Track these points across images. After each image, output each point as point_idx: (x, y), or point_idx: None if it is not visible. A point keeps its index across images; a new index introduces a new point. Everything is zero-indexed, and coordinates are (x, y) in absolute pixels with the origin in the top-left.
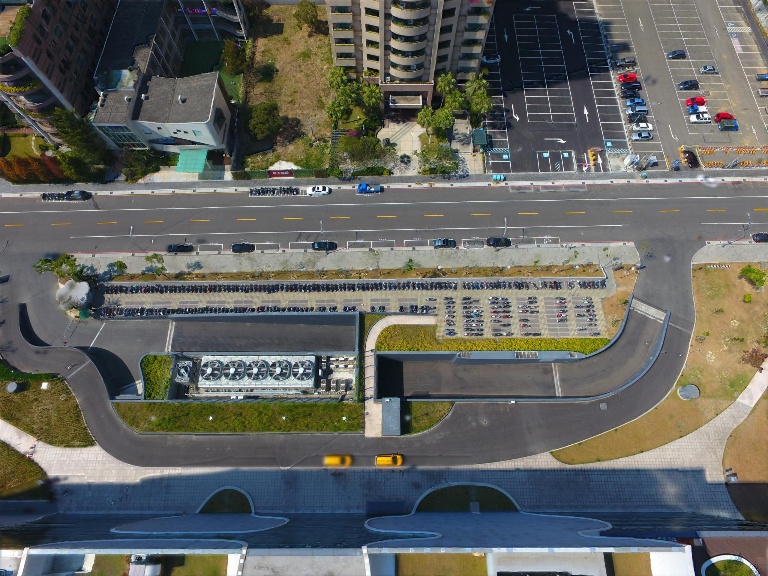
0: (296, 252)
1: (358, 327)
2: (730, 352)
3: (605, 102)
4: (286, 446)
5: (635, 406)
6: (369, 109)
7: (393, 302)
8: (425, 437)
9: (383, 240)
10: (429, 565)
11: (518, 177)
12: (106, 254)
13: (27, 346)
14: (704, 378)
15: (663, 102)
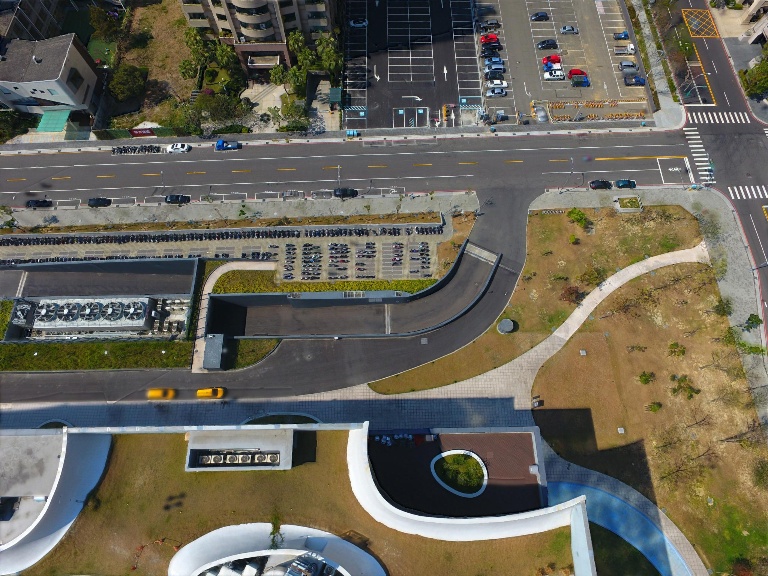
0: (150, 205)
1: (196, 272)
2: (553, 290)
3: (465, 62)
4: (115, 382)
5: (455, 341)
6: (234, 71)
7: (237, 250)
8: (249, 372)
9: (235, 193)
10: (144, 450)
11: (372, 133)
12: None
13: None
14: (524, 314)
15: (521, 61)
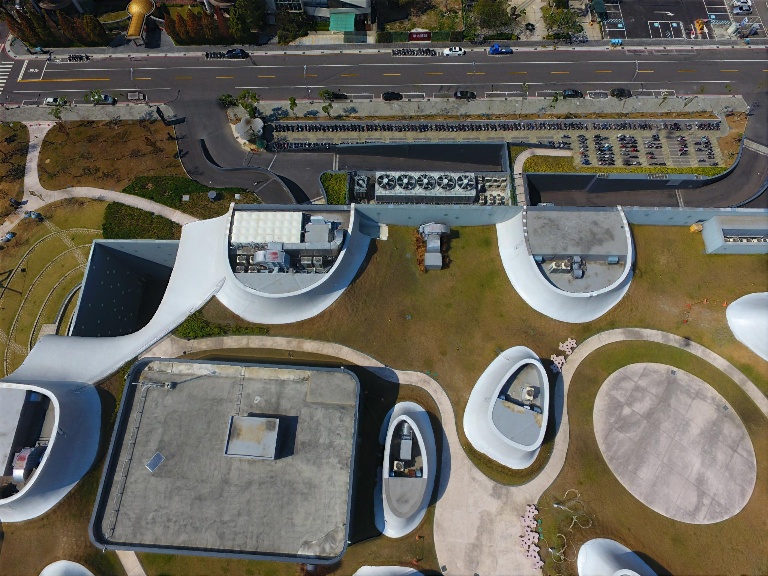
0: (440, 100)
1: (507, 153)
2: None
3: None
4: None
5: None
6: None
7: (532, 139)
8: None
9: (517, 91)
10: (657, 238)
11: (633, 42)
12: (269, 101)
13: (213, 170)
14: None
15: None
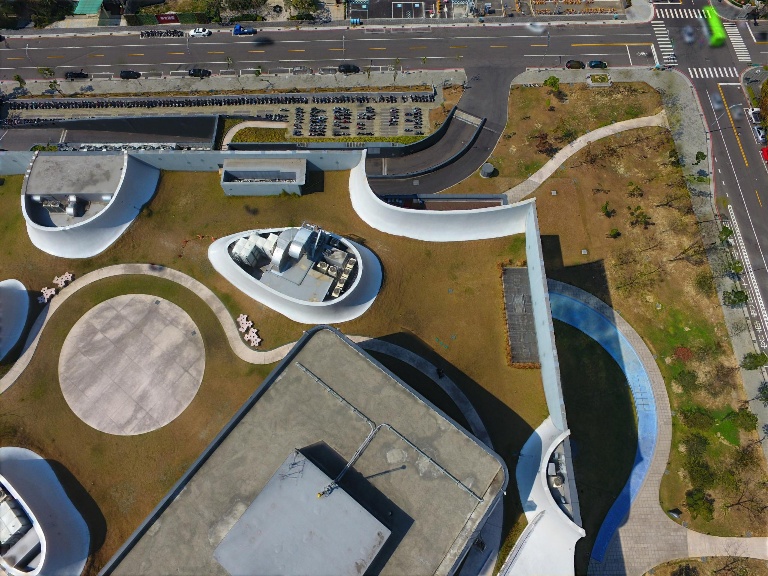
0: (175, 78)
1: (217, 125)
2: (530, 146)
3: None
4: None
5: (443, 183)
6: None
7: (253, 113)
8: None
9: (251, 69)
10: (185, 182)
11: (373, 22)
12: (13, 81)
13: None
14: (504, 163)
15: None
